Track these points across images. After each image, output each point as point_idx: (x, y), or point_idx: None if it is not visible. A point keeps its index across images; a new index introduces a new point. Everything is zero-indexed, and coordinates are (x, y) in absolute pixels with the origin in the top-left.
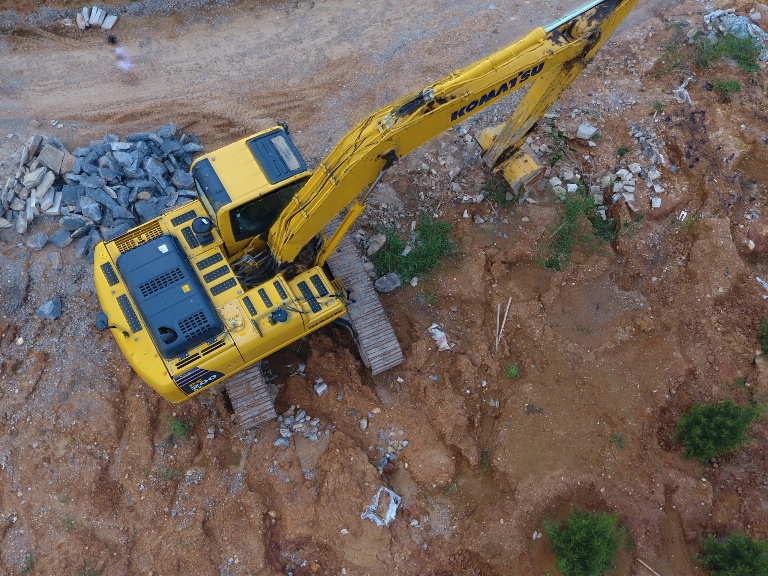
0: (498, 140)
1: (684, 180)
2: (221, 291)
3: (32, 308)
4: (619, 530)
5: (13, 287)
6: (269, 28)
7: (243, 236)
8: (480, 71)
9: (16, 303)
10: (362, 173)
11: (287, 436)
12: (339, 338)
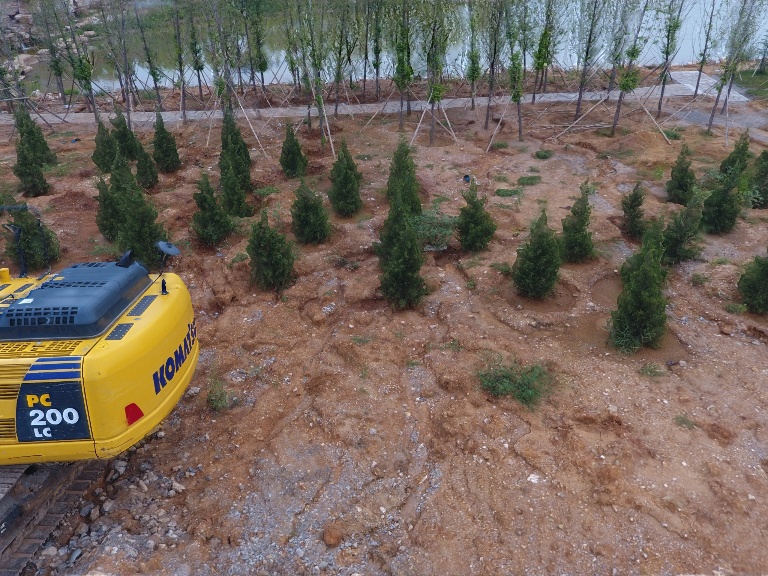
0: None
1: None
2: None
3: None
4: (3, 258)
5: None
6: None
7: None
8: None
9: None
10: None
11: None
12: None
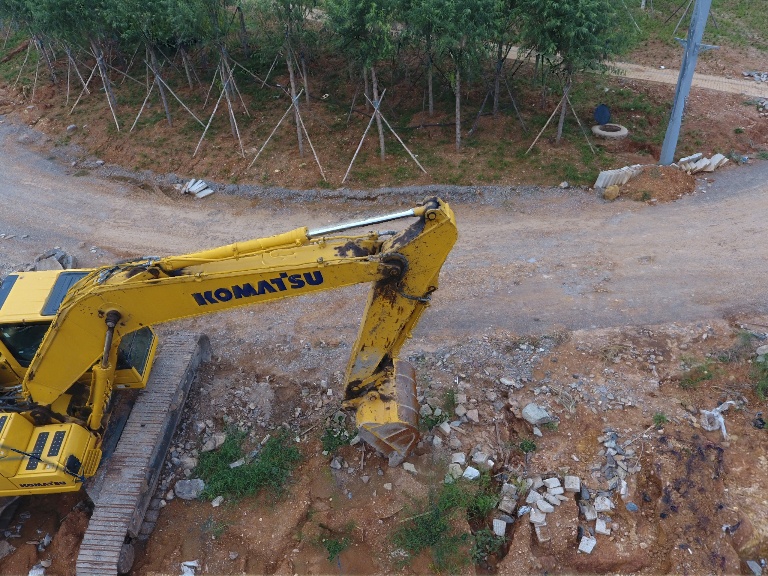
0: (347, 367)
1: (650, 532)
2: None
3: None
4: None
5: None
6: (314, 226)
7: (30, 363)
8: (219, 253)
9: None
10: (91, 327)
11: None
12: None
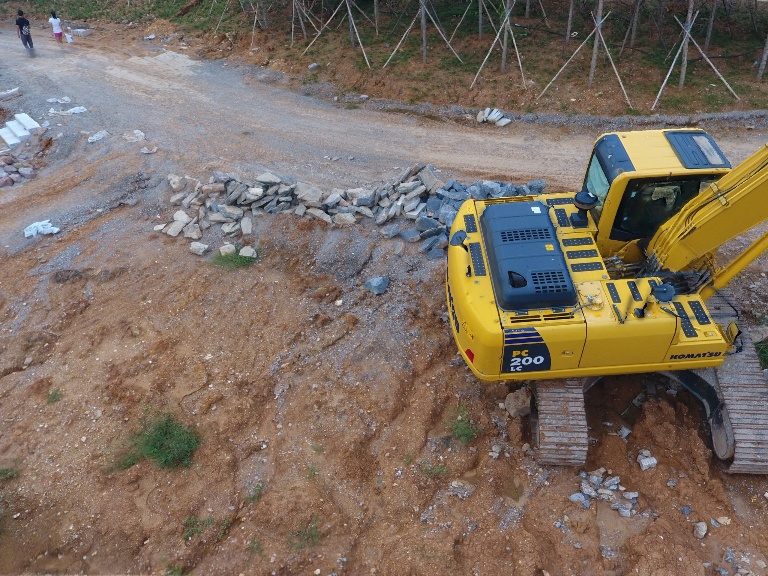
0: None
1: None
2: (583, 270)
3: (361, 281)
4: None
5: (354, 259)
6: None
7: (620, 234)
8: None
9: (350, 272)
10: None
11: (590, 494)
12: (684, 416)
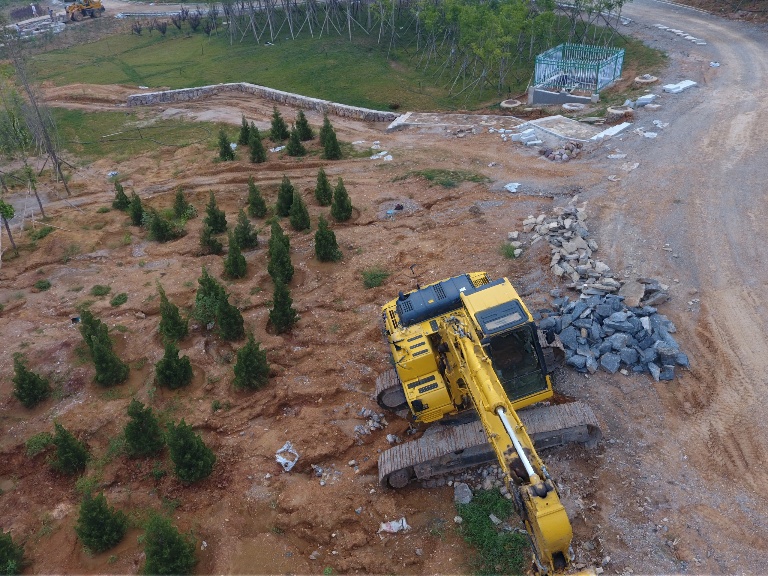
0: None
1: None
2: None
3: None
4: None
5: None
6: None
7: None
8: None
9: None
10: None
11: None
12: None
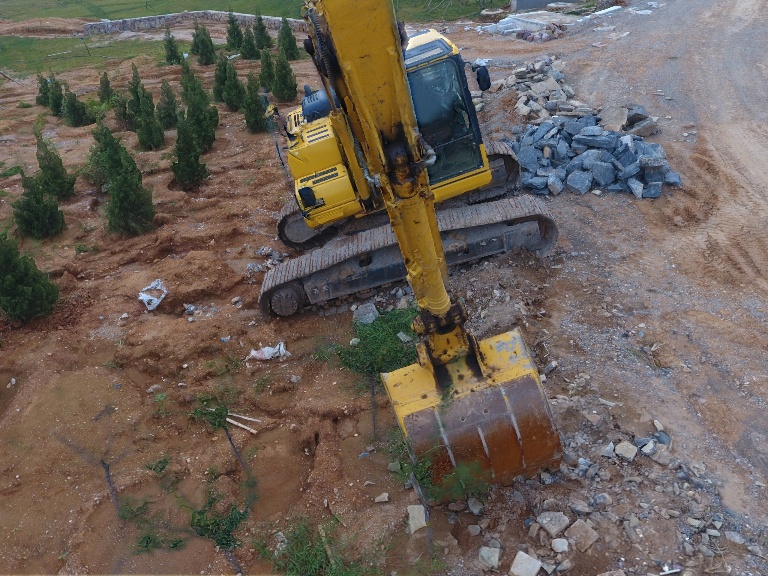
0: None
1: None
2: None
3: None
4: None
5: None
6: None
7: None
8: None
9: None
10: None
11: None
12: None
